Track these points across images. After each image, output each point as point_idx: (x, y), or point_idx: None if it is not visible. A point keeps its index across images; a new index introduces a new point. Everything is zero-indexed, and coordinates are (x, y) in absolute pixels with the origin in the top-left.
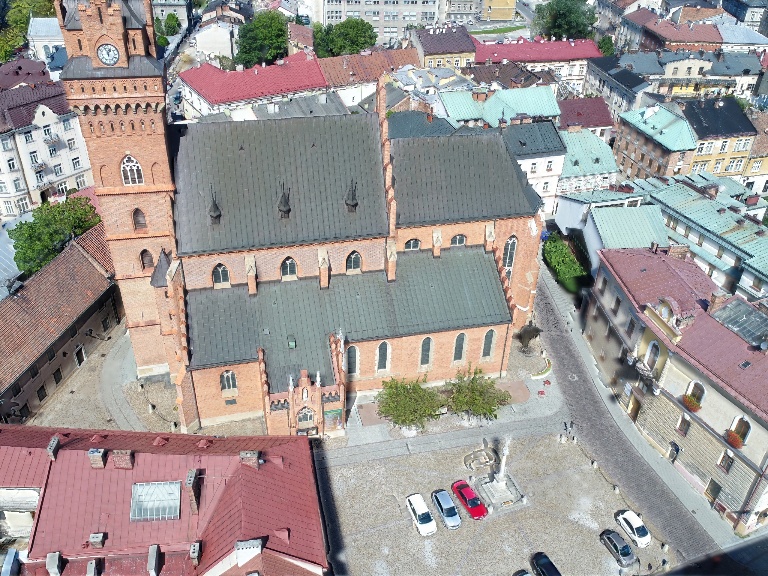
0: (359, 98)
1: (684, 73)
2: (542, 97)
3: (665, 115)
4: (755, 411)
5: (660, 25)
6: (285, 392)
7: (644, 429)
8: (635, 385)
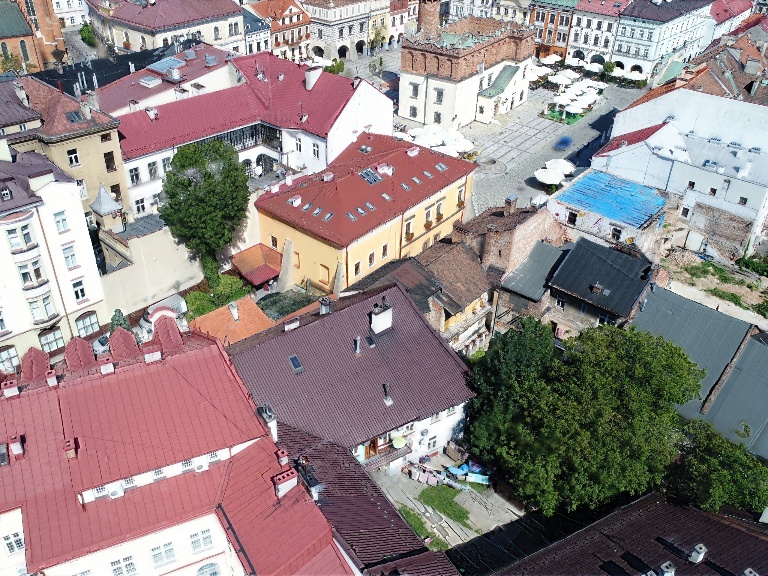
0: None
1: None
2: None
3: None
4: (141, 27)
5: None
6: None
7: None
8: None
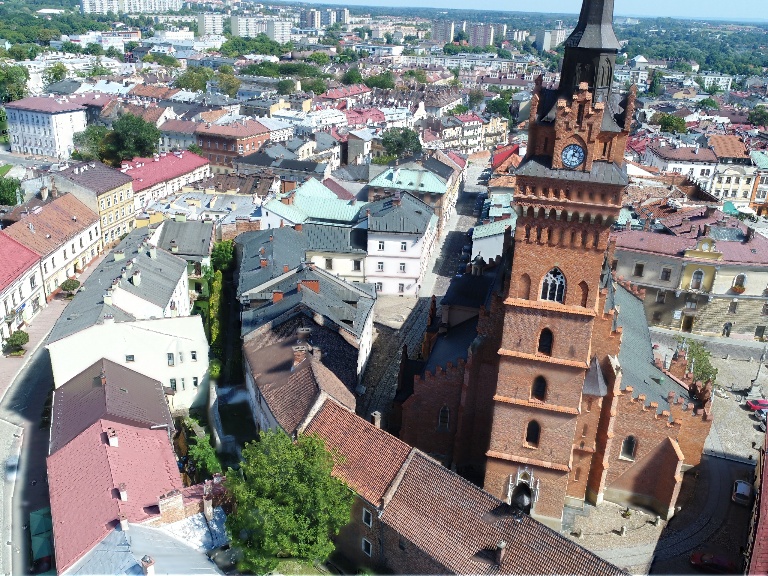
0: (156, 245)
1: (307, 154)
2: (319, 187)
3: (408, 173)
4: None
5: (214, 128)
6: (705, 409)
7: (702, 330)
8: (685, 308)
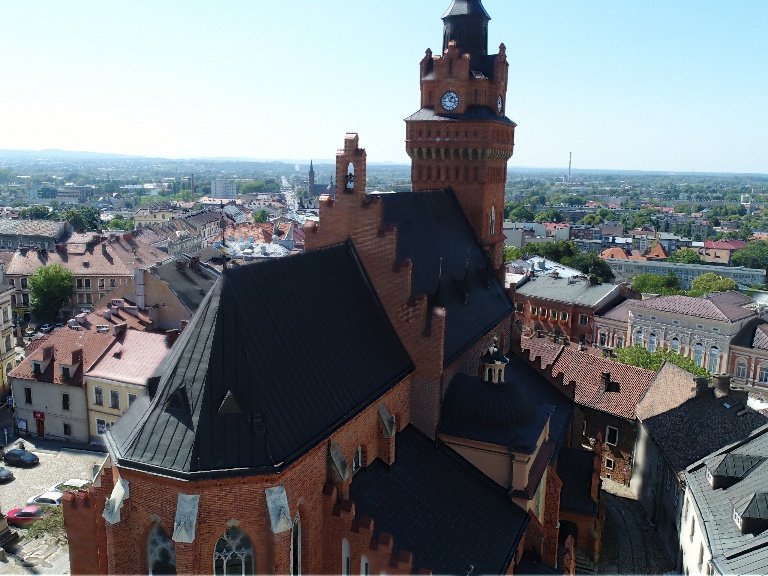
0: None
1: None
2: None
3: None
4: None
5: None
6: None
7: None
8: None
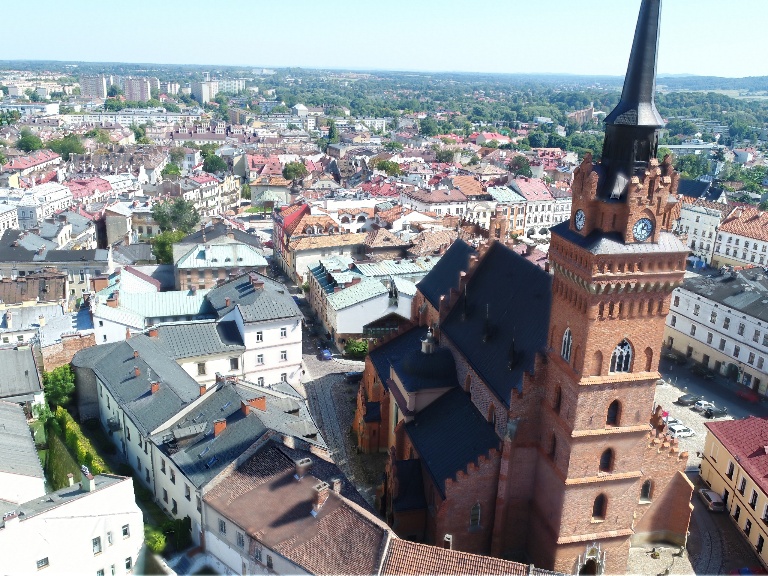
0: None
1: (65, 240)
2: (134, 280)
3: (221, 249)
4: None
5: None
6: None
7: None
8: None
